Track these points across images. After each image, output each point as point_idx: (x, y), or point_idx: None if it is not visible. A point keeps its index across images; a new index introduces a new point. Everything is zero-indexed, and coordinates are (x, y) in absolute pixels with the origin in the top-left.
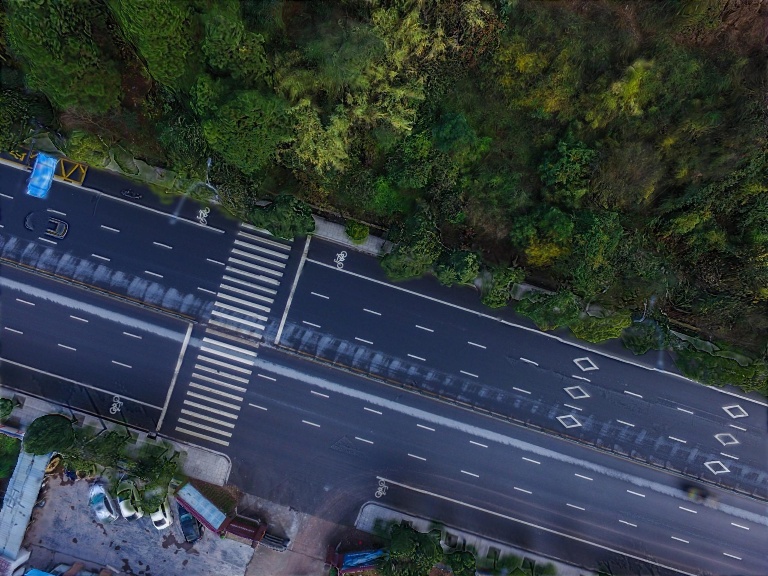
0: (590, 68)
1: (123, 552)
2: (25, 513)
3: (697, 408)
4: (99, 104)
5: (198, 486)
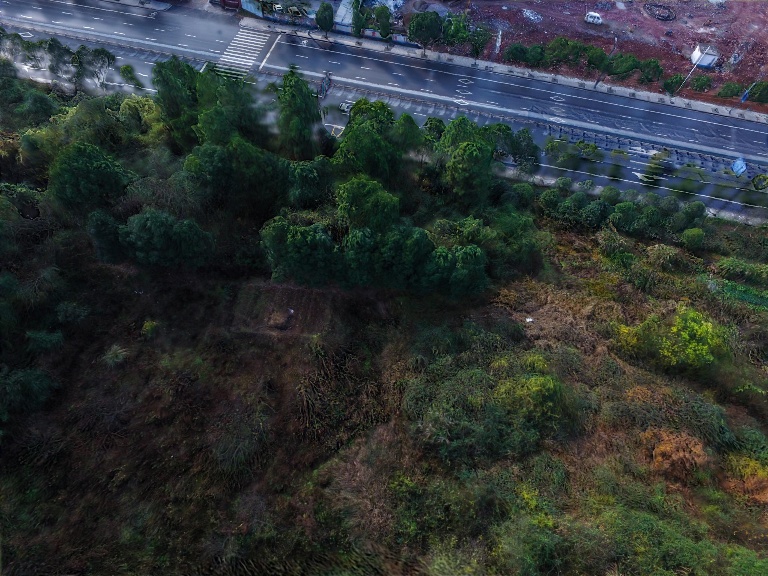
0: None
1: (300, 2)
2: (343, 5)
3: None
4: None
5: (257, 17)
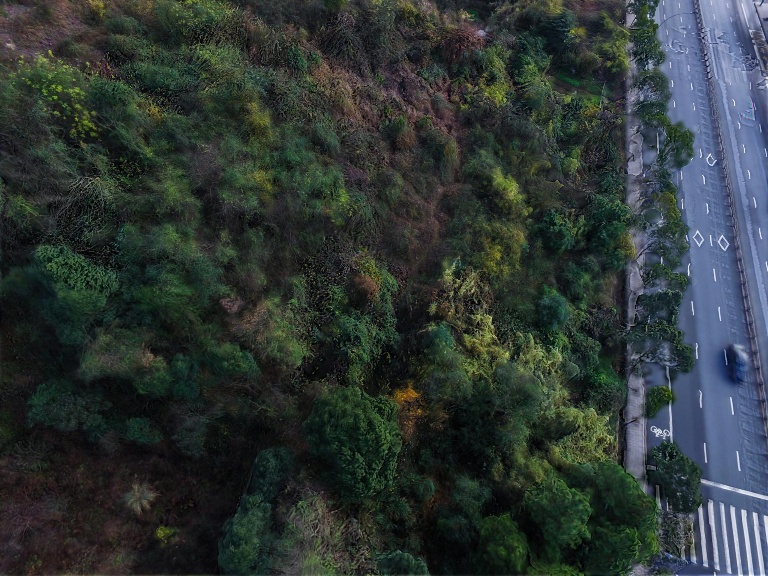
0: None
1: None
2: None
3: None
4: None
5: None
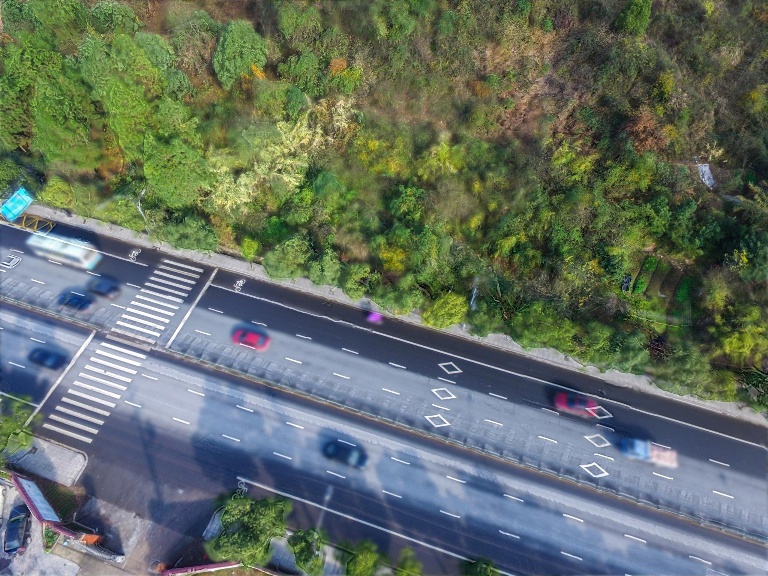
0: (418, 147)
1: None
2: None
3: (561, 409)
4: (78, 165)
5: (43, 486)
